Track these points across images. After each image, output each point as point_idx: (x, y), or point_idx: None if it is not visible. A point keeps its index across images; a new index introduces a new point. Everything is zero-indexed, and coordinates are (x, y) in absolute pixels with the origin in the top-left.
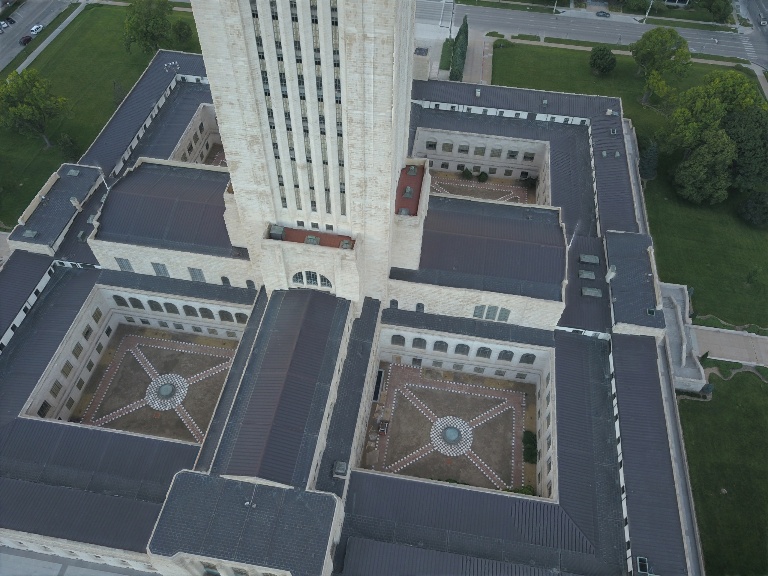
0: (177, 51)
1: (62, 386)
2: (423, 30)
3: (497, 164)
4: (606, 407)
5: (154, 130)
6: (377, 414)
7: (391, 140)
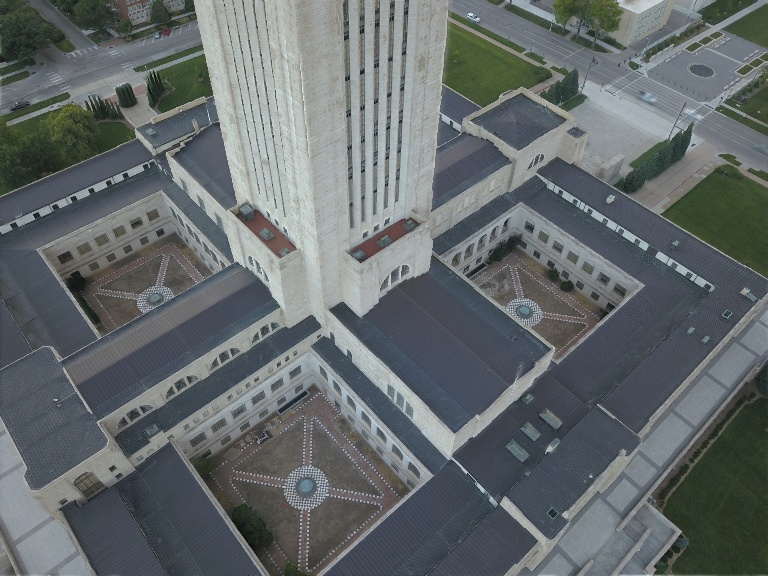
0: None
1: (92, 250)
2: (652, 122)
3: (586, 280)
4: (427, 567)
5: None
6: (270, 424)
7: (310, 169)
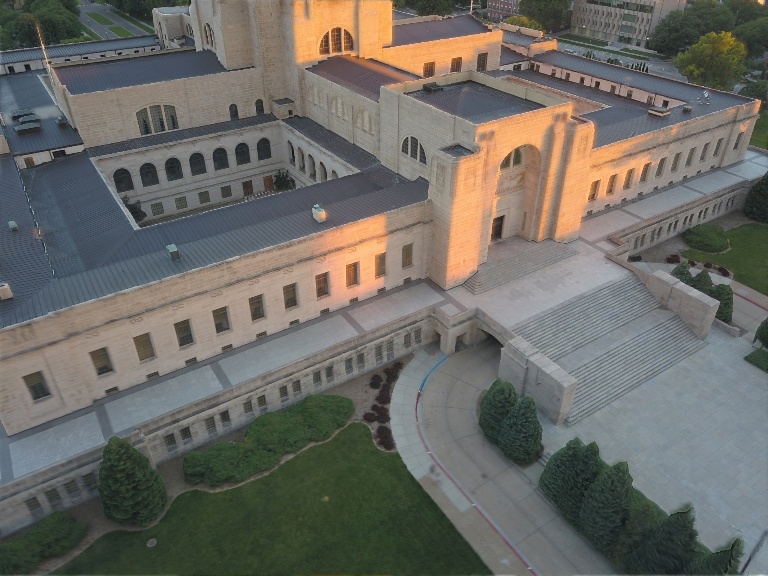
0: (744, 104)
1: None
2: None
3: None
4: (3, 108)
5: (594, 92)
6: None
7: None
